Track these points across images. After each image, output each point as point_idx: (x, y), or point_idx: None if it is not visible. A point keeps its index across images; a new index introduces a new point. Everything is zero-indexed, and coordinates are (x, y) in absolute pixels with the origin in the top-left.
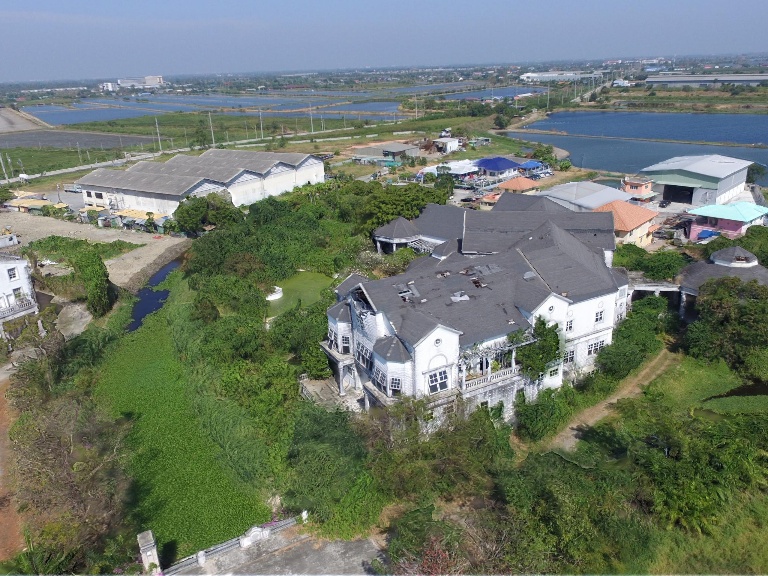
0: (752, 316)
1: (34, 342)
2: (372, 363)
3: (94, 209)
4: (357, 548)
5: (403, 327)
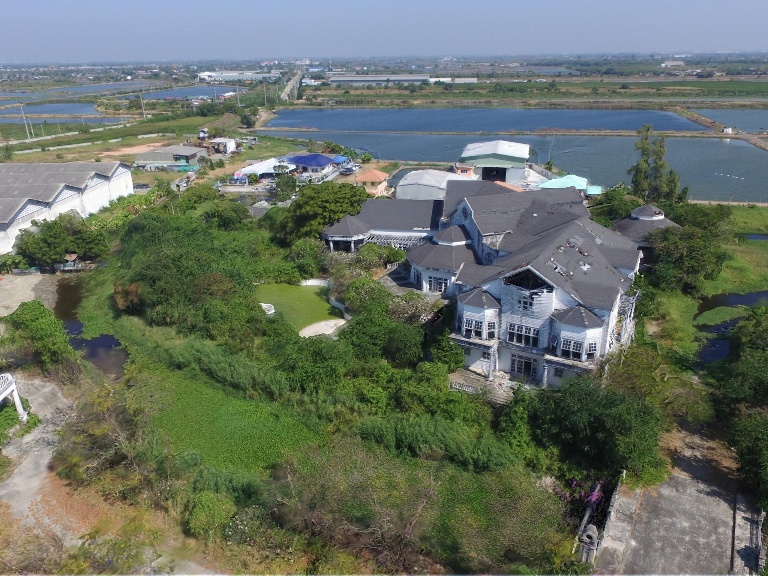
0: (699, 252)
1: None
2: (538, 339)
3: None
4: (679, 484)
5: (583, 297)
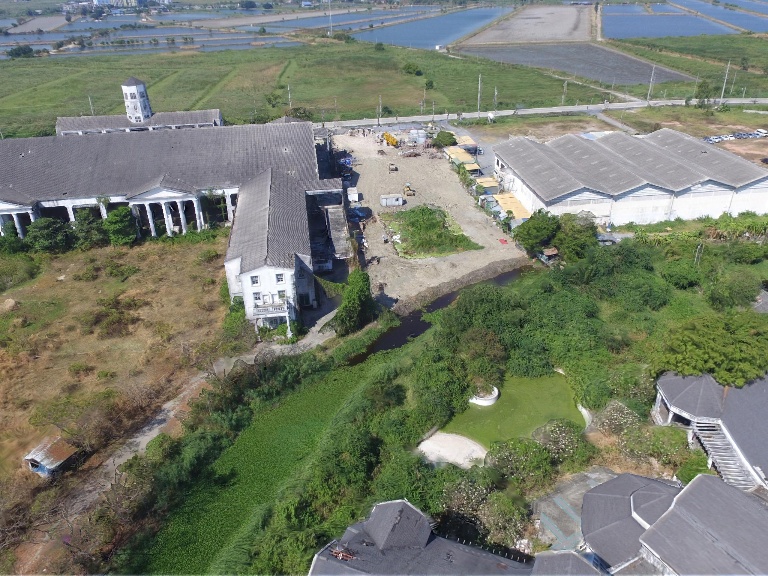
0: None
1: (208, 371)
2: None
3: (487, 183)
4: None
5: None
